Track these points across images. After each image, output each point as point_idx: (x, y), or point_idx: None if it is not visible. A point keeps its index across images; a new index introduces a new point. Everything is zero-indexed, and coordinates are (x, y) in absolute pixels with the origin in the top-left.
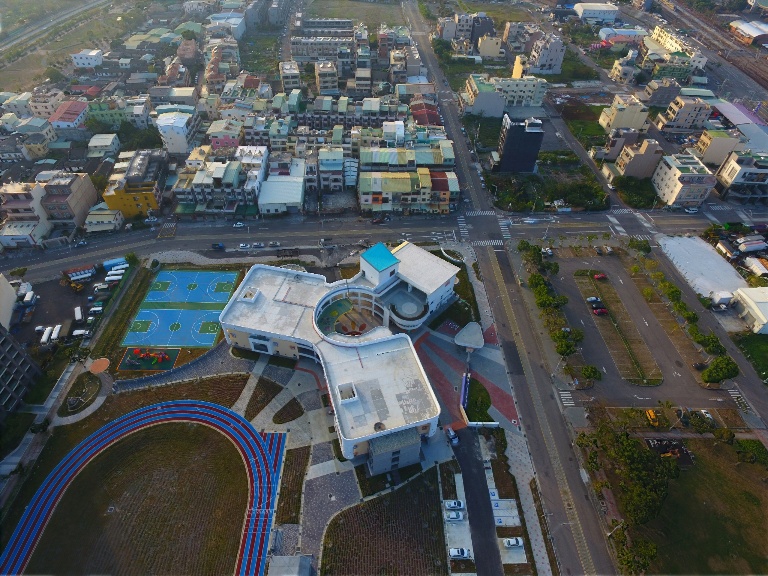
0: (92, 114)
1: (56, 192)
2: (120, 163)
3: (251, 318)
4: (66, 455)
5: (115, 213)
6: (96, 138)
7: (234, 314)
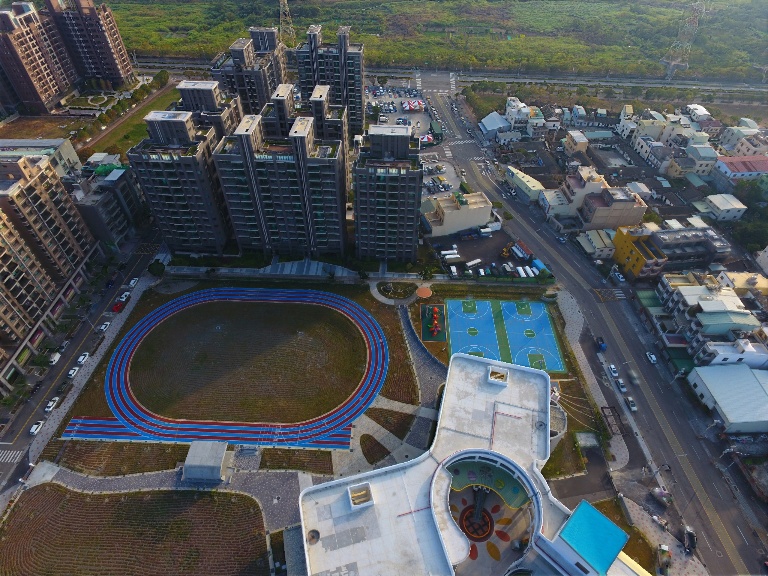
0: (764, 179)
1: (606, 198)
2: (677, 222)
3: (464, 383)
4: (344, 297)
5: (608, 246)
6: (724, 197)
7: (468, 366)
